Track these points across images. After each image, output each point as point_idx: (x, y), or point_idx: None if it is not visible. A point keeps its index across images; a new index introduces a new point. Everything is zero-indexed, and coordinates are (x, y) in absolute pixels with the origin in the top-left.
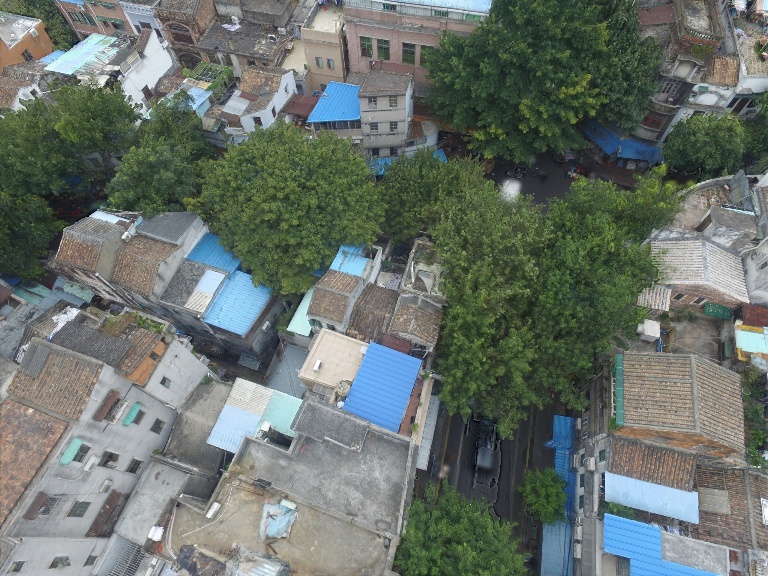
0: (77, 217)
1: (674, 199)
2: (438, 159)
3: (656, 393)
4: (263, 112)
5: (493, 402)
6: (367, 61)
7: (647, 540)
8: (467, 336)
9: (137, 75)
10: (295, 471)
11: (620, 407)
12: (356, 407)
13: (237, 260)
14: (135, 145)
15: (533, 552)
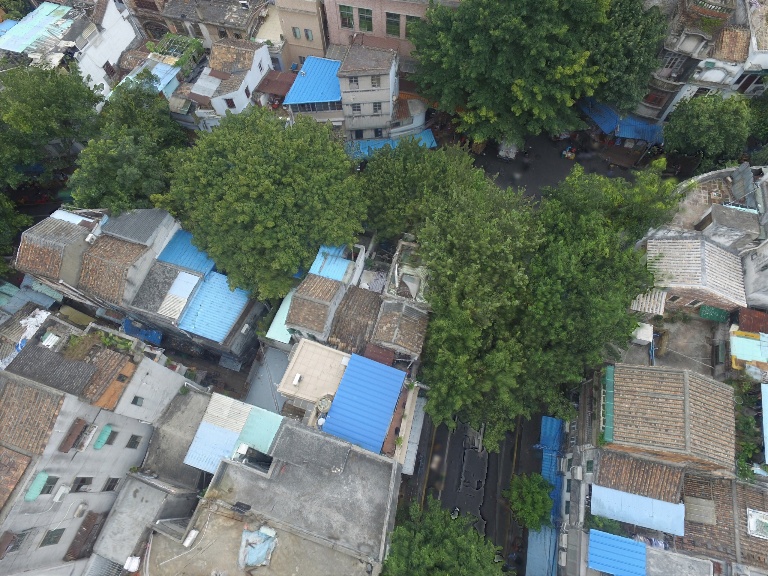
0: (44, 205)
1: (674, 198)
2: (424, 148)
3: (647, 410)
4: (235, 93)
5: (479, 413)
6: (348, 32)
7: (632, 556)
8: (453, 348)
9: (96, 50)
10: (275, 493)
11: (609, 423)
12: (337, 424)
13: (212, 260)
14: (97, 132)
15: (519, 551)
